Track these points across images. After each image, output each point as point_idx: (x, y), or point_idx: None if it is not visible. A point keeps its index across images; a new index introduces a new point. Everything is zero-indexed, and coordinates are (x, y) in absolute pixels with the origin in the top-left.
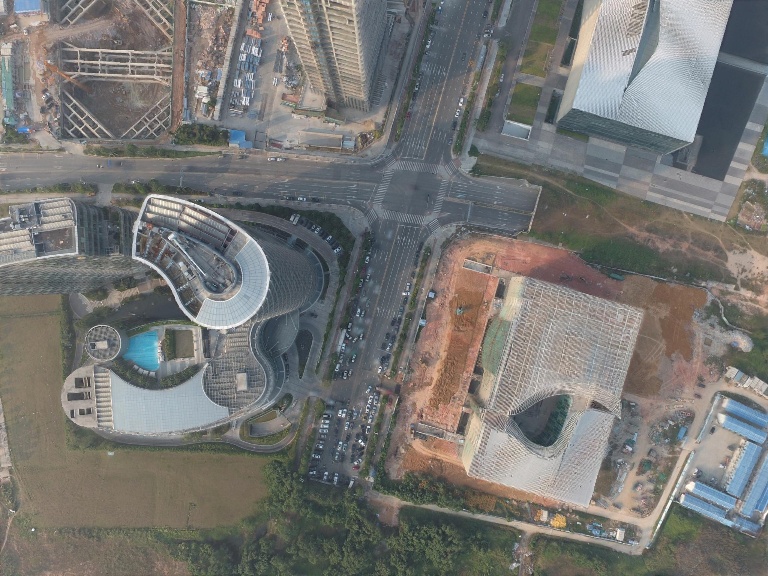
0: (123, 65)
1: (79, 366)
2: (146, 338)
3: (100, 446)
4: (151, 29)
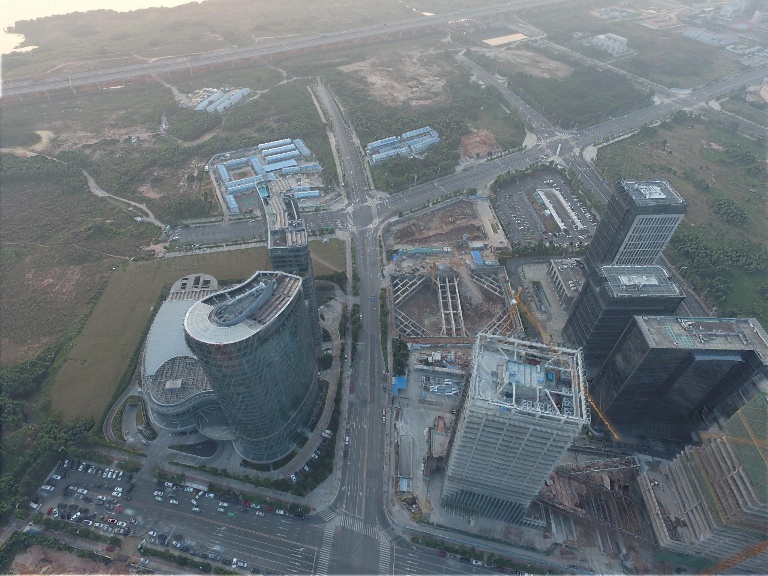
0: None
1: None
2: None
3: (159, 300)
4: None
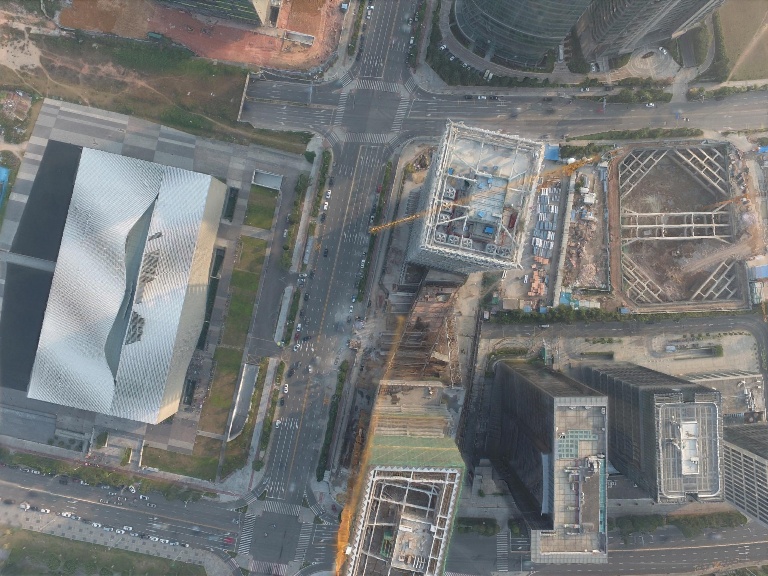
0: (669, 235)
1: None
2: None
3: None
4: None
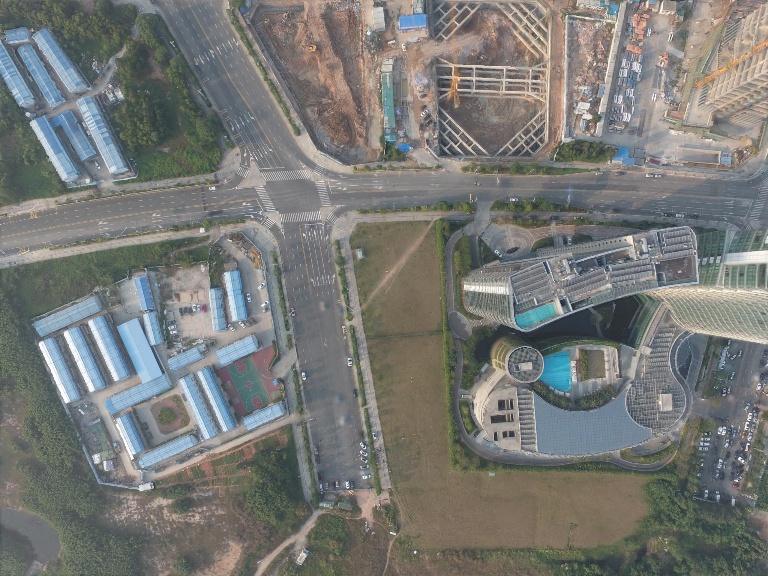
0: None
1: (462, 386)
2: (556, 358)
3: (491, 467)
4: (511, 44)
